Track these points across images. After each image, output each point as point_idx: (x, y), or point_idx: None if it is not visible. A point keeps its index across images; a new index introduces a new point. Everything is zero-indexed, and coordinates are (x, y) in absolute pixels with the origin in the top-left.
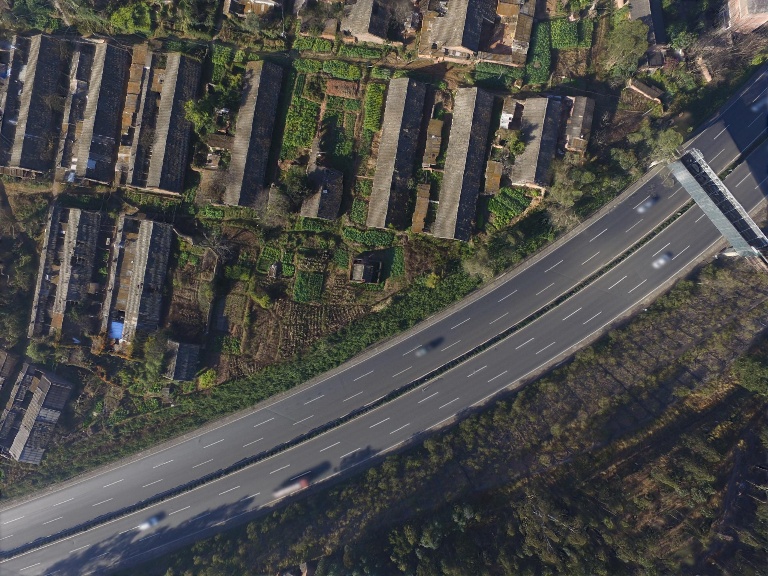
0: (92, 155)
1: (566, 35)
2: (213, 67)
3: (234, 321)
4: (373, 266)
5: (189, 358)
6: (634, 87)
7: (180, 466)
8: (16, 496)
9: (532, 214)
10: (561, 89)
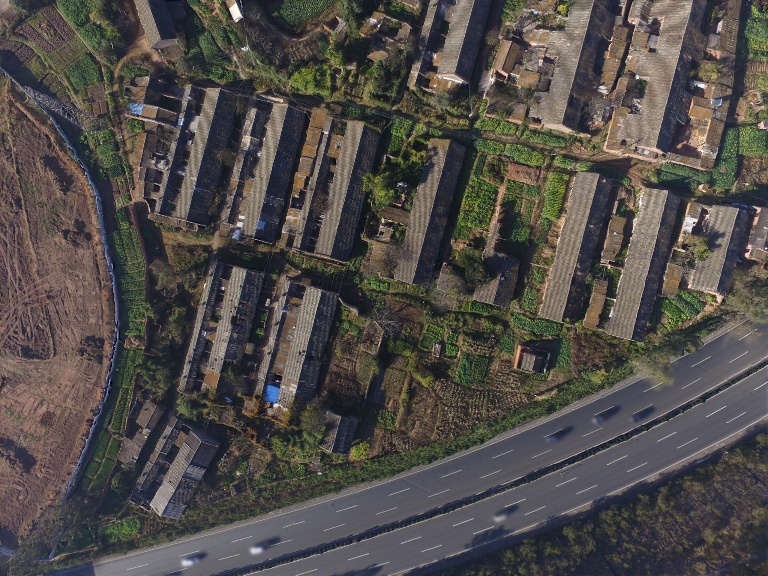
0: (263, 216)
1: (754, 143)
2: (390, 137)
3: (391, 395)
4: (542, 356)
5: (348, 431)
6: None
7: (311, 528)
8: (146, 546)
9: (705, 319)
10: (744, 196)
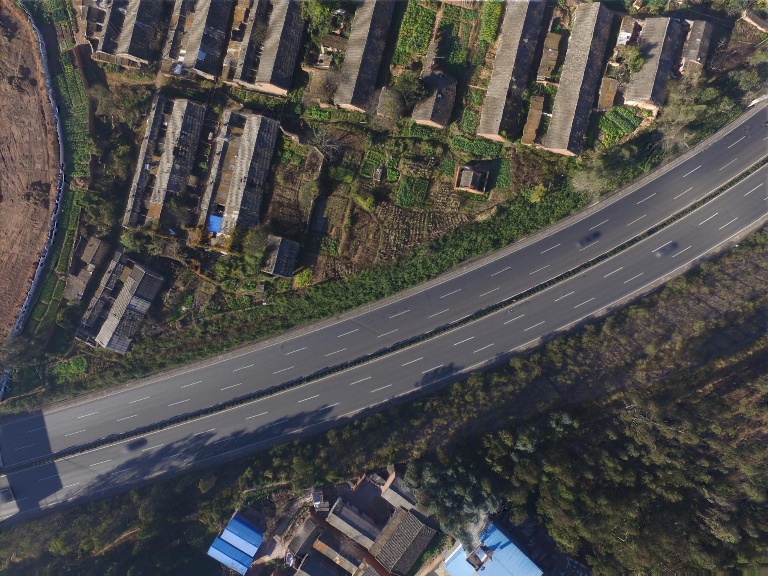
0: (203, 46)
1: None
2: None
3: (334, 223)
4: (481, 175)
5: (289, 254)
6: (748, 19)
7: (260, 371)
8: (95, 388)
9: (642, 134)
10: (678, 14)
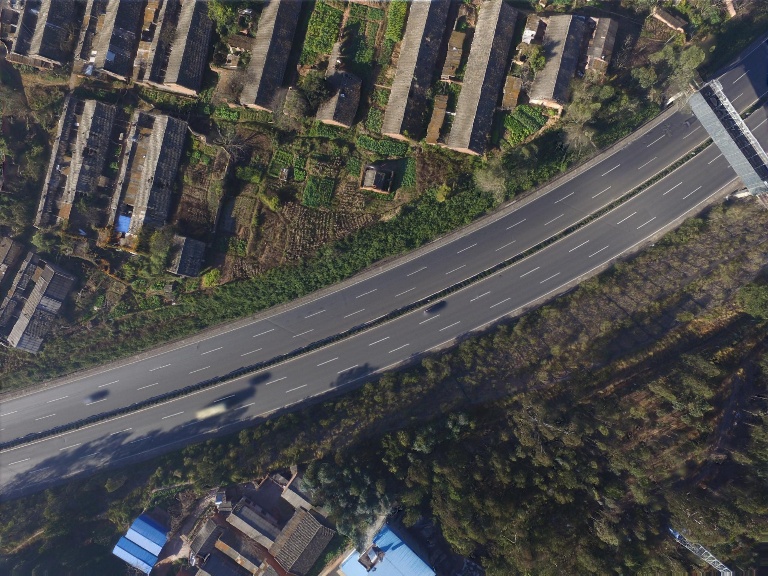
0: (112, 47)
1: None
2: None
3: (242, 223)
4: (385, 174)
5: (194, 254)
6: (658, 16)
7: (177, 371)
8: (11, 388)
9: (547, 133)
10: (585, 12)
